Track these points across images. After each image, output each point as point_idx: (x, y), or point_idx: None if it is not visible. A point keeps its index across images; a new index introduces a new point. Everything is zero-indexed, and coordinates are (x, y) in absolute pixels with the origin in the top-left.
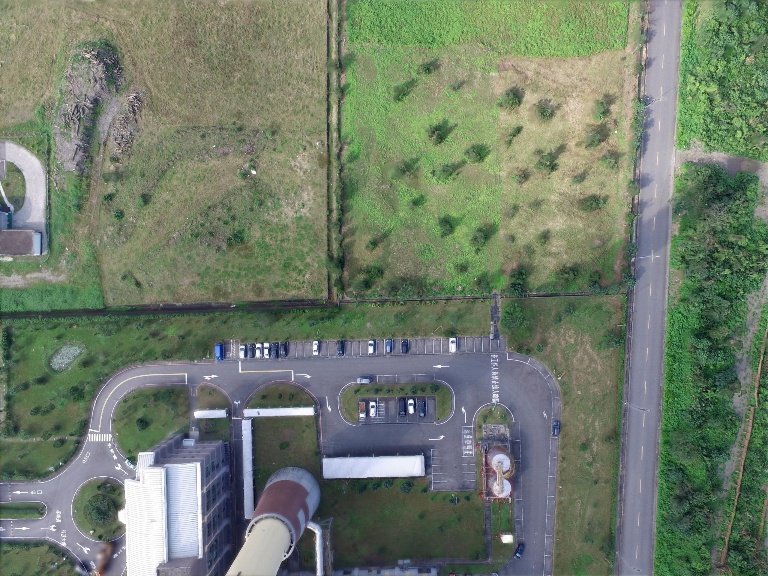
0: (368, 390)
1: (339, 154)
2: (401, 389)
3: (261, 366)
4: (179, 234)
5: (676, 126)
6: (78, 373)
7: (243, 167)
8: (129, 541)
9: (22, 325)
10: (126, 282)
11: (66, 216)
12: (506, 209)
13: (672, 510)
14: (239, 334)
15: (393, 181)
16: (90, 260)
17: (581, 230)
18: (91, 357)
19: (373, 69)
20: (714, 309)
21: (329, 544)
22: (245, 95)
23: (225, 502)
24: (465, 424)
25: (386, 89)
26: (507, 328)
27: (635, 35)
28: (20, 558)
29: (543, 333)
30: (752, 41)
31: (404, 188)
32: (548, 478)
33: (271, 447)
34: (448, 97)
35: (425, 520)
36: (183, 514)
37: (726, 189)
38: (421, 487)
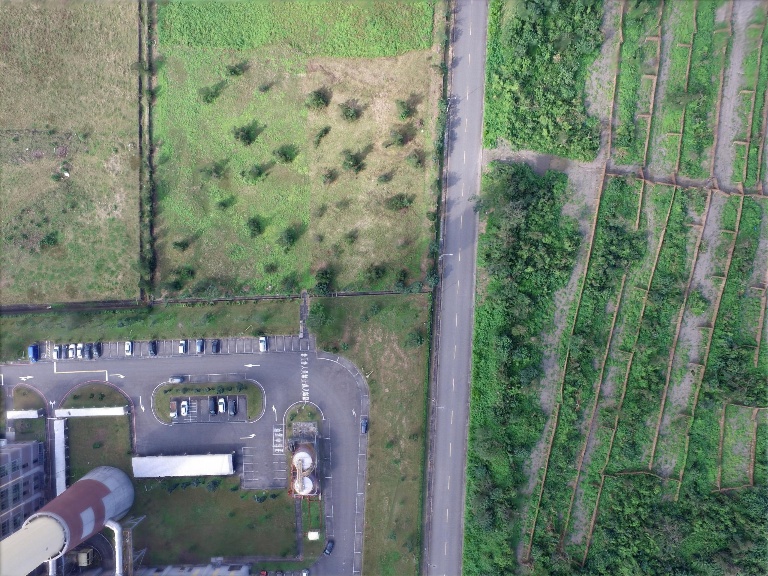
0: (178, 390)
1: (150, 156)
2: (211, 388)
3: (76, 367)
4: None
5: (483, 125)
6: None
7: (57, 170)
8: None
9: None
10: None
11: None
12: (315, 209)
13: None
14: (53, 335)
15: (204, 182)
16: None
17: (389, 229)
18: None
19: (184, 71)
20: (516, 306)
21: (130, 542)
22: (58, 98)
23: (39, 501)
24: (276, 422)
25: (196, 91)
26: (310, 327)
27: (440, 35)
28: None
29: (351, 332)
30: (555, 39)
31: (215, 189)
32: (357, 475)
33: (86, 447)
34: (257, 98)
35: (237, 518)
36: None
37: (532, 187)
38: (232, 485)
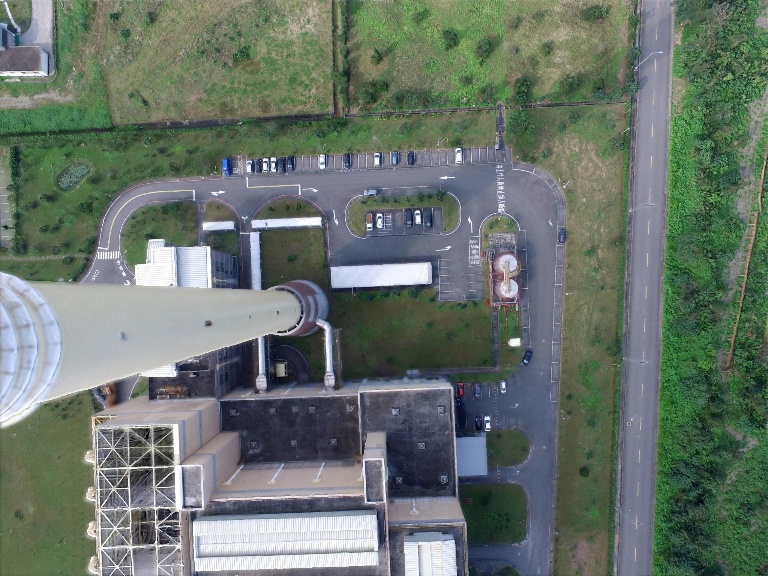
0: (375, 200)
1: None
2: (408, 199)
3: (268, 181)
4: (185, 51)
5: None
6: (86, 191)
7: None
8: None
9: (30, 145)
10: (133, 100)
11: (73, 35)
12: (510, 21)
13: (678, 314)
14: (246, 149)
15: None
16: (97, 79)
17: (584, 40)
18: (99, 175)
19: None
20: (717, 112)
21: (338, 343)
22: None
23: None
24: (471, 234)
25: None
26: (512, 132)
27: None
28: None
29: (548, 142)
30: None
31: (408, 2)
32: (554, 286)
33: (279, 261)
34: None
35: (433, 330)
36: None
37: None
38: (428, 297)
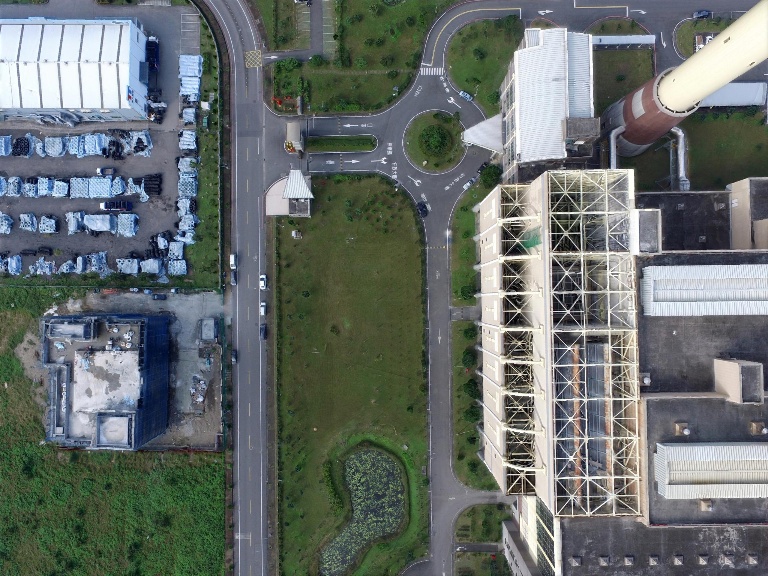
0: (708, 21)
1: None
2: None
3: (596, 2)
4: None
5: None
6: (412, 6)
7: None
8: (521, 109)
9: None
10: None
11: None
12: None
13: None
14: None
15: None
16: None
17: None
18: None
19: None
20: None
21: None
22: None
23: None
24: None
25: None
26: None
27: None
28: (349, 191)
29: None
30: None
31: None
32: None
33: (606, 81)
34: None
35: (760, 153)
36: (578, 81)
37: None
38: (757, 121)
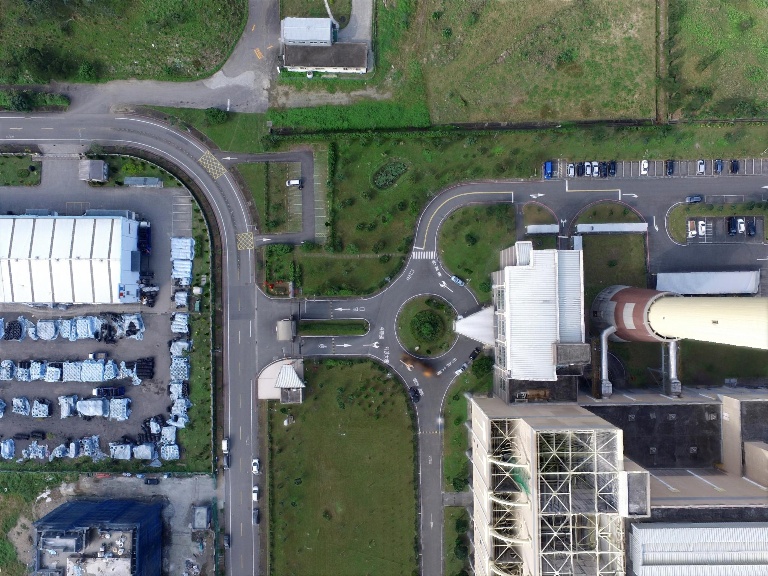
0: (701, 207)
1: None
2: None
3: (588, 185)
4: (508, 53)
5: None
6: (404, 190)
7: None
8: (512, 326)
9: None
10: (453, 100)
11: (394, 33)
12: None
13: None
14: (567, 153)
15: (722, 4)
16: (417, 77)
17: None
18: (417, 174)
19: None
20: None
21: None
22: None
23: None
24: None
25: None
26: None
27: None
28: (342, 375)
29: None
30: None
31: (733, 11)
32: None
33: (598, 265)
34: None
35: None
36: (568, 299)
37: None
38: None
